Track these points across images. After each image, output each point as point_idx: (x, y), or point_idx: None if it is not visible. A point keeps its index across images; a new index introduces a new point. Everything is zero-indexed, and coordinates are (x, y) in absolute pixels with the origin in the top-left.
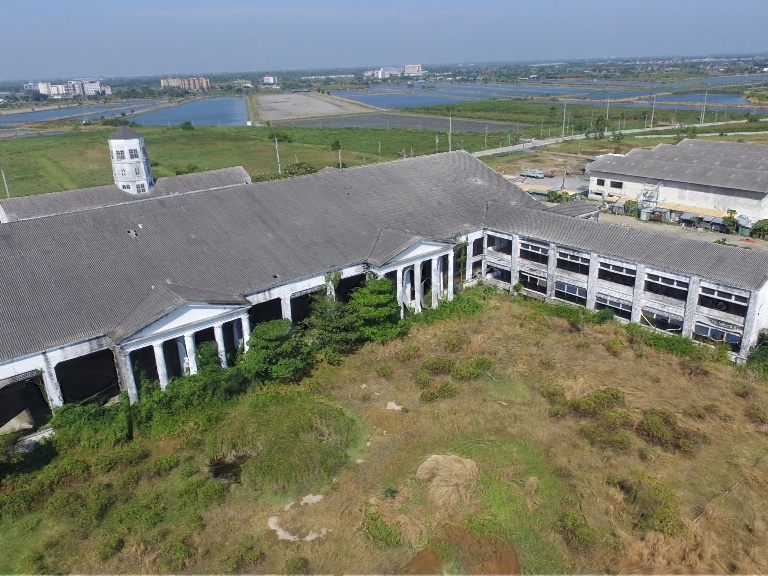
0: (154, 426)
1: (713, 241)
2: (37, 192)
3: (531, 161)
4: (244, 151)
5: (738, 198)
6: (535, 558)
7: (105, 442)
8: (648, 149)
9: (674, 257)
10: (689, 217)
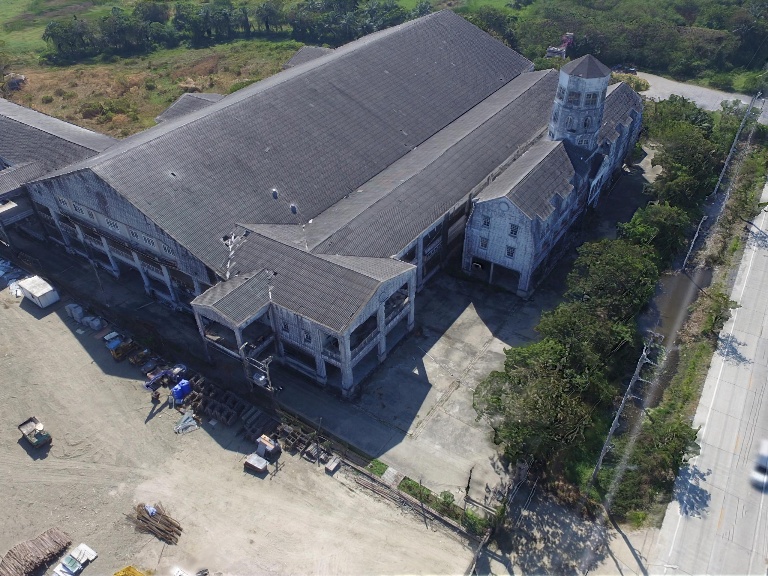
0: None
1: None
2: None
3: None
4: None
5: None
6: (167, 83)
7: None
8: None
9: (8, 106)
10: None
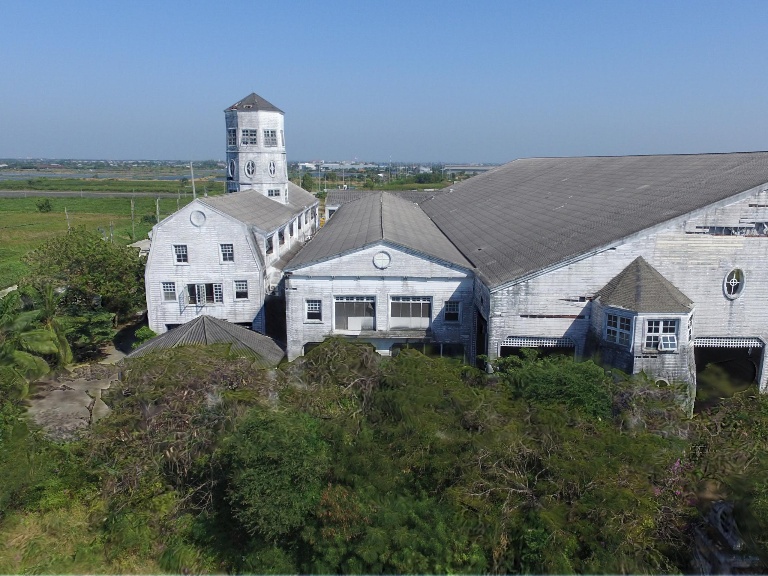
0: None
1: None
2: None
3: None
4: None
5: None
6: None
7: None
8: None
9: None
10: None
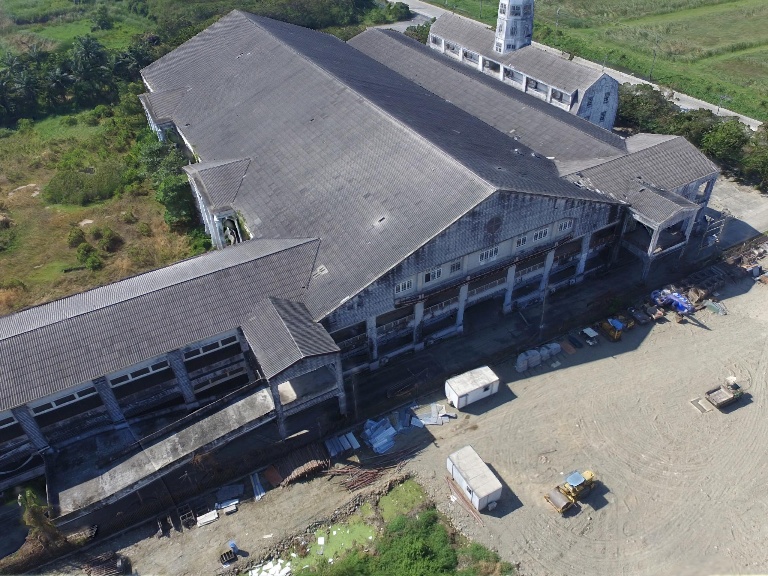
0: None
1: None
2: (758, 29)
3: None
4: None
5: None
6: None
7: None
8: None
9: None
10: None
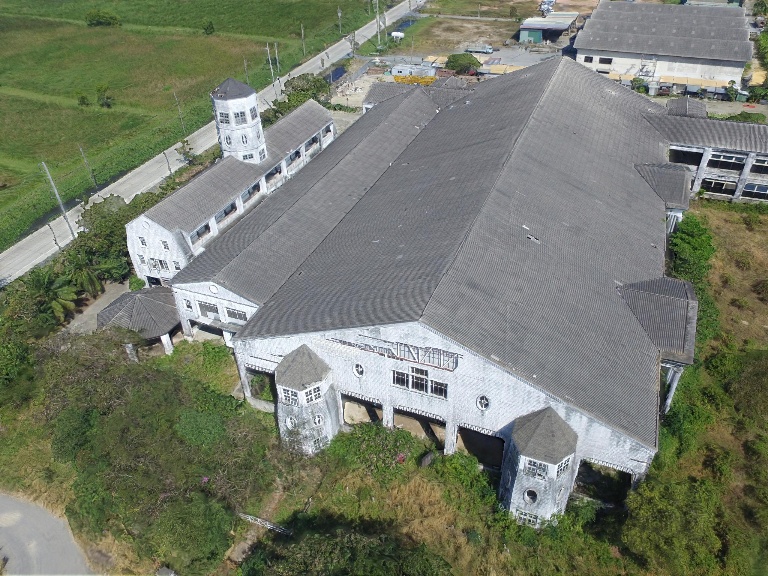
0: (696, 422)
1: (730, 111)
2: None
3: (447, 30)
4: (91, 47)
5: (724, 67)
6: None
7: (685, 453)
8: (523, 4)
9: None
10: (696, 90)
